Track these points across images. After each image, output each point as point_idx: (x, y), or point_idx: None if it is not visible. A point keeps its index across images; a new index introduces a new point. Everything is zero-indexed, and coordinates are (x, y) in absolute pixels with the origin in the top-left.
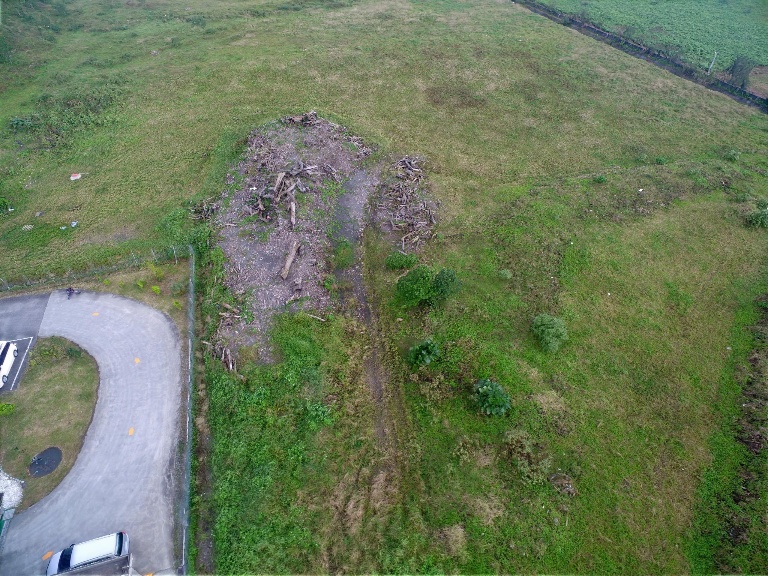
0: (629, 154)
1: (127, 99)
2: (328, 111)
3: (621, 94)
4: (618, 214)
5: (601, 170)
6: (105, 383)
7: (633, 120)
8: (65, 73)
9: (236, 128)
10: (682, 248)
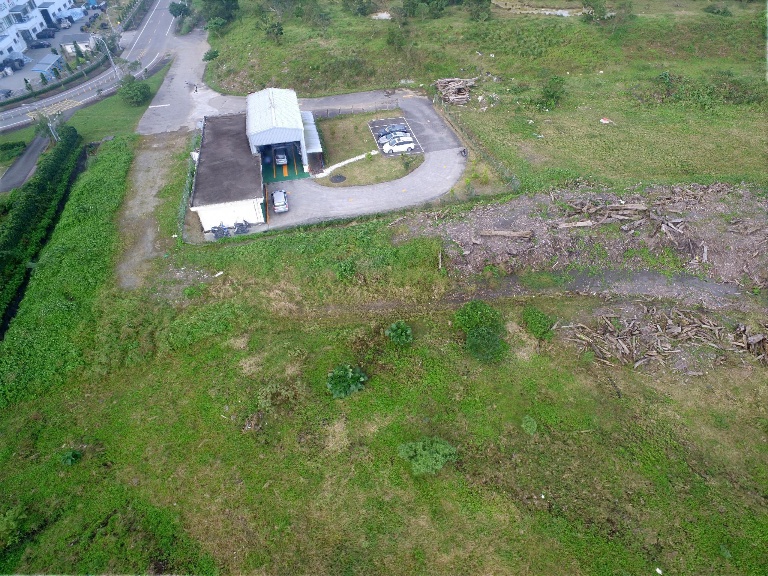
0: None
1: None
2: None
3: None
4: None
5: None
6: (387, 184)
7: None
8: None
9: (766, 179)
10: None
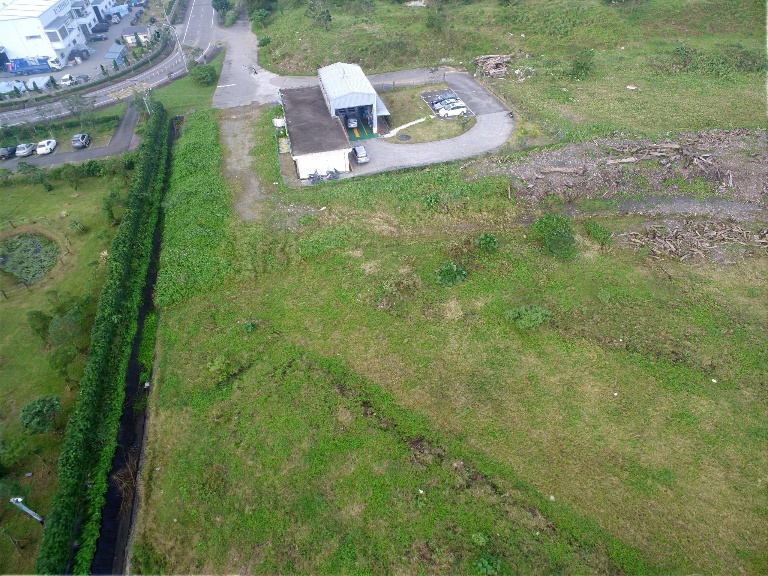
0: None
1: None
2: None
3: None
4: None
5: None
6: (448, 140)
7: None
8: None
9: None
10: None
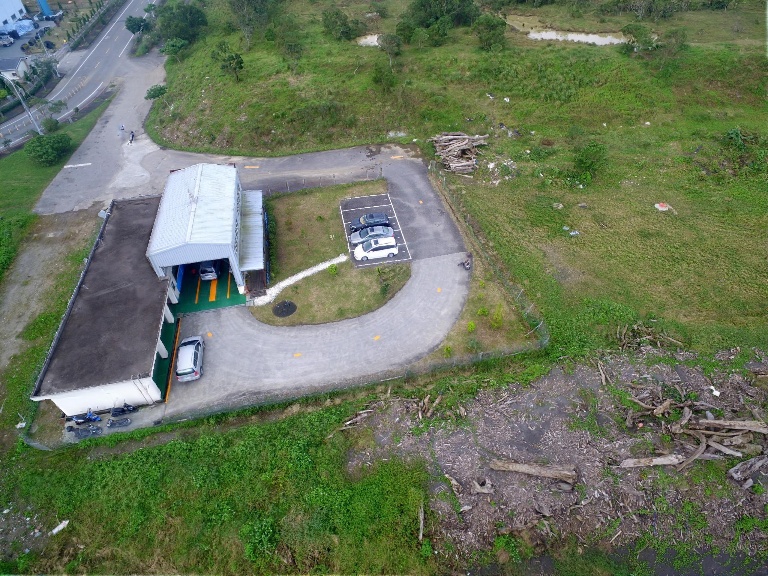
0: None
1: None
2: None
3: None
4: None
5: None
6: (354, 321)
7: None
8: None
9: None
10: None
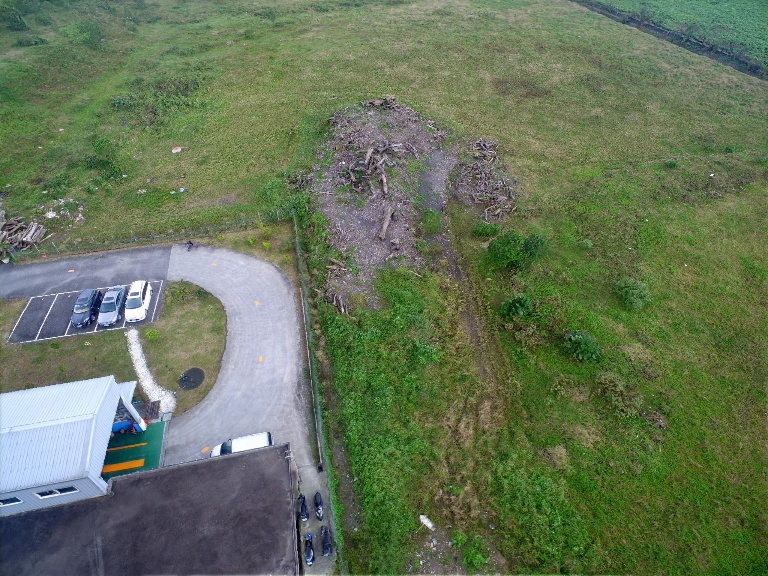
0: (697, 143)
1: (211, 84)
2: (400, 98)
3: (686, 88)
4: (691, 196)
5: (671, 156)
6: (232, 320)
7: (699, 112)
8: (151, 60)
9: (316, 111)
10: (755, 228)
